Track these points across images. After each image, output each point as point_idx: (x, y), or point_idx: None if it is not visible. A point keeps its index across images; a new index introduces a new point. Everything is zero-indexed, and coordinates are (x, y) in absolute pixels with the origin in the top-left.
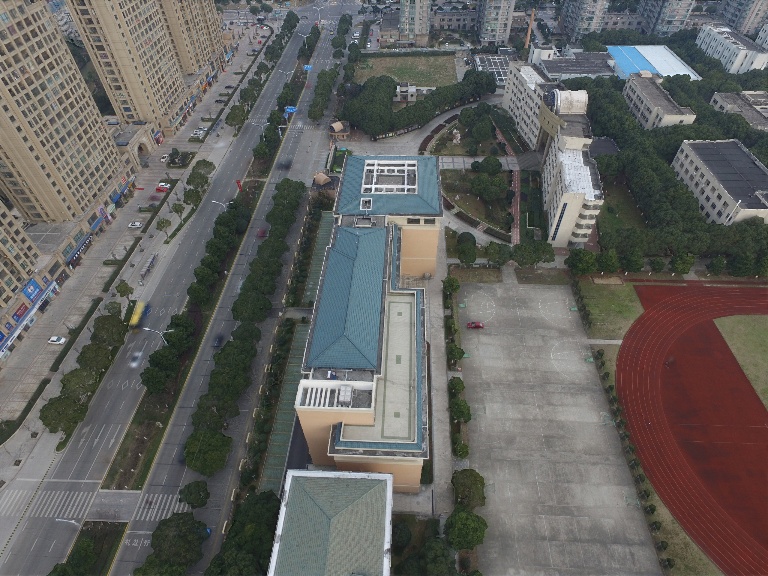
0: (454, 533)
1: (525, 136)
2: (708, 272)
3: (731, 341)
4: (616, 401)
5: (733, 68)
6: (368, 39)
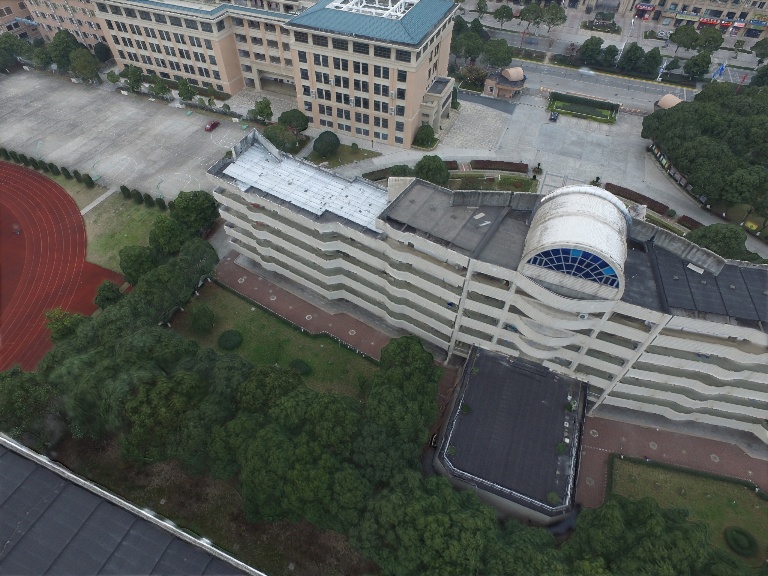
0: None
1: None
2: None
3: None
4: None
5: None
6: None
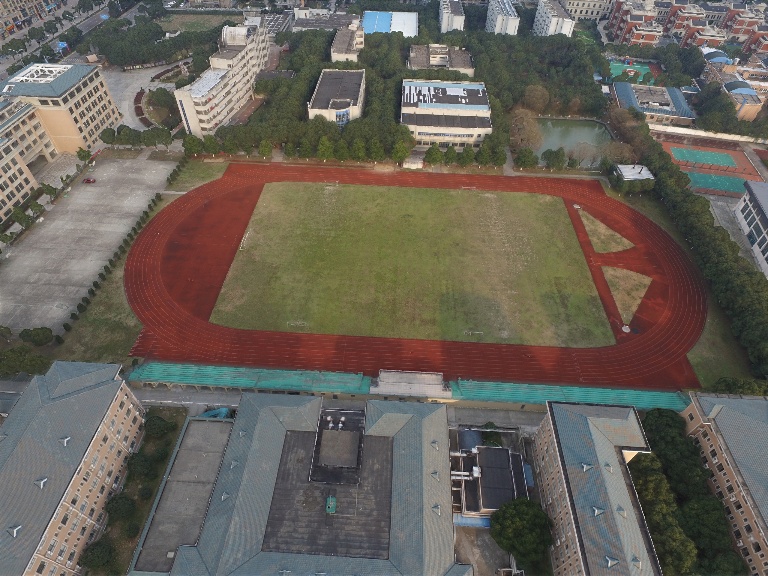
0: None
1: None
2: None
3: (264, 195)
4: (143, 220)
5: (443, 29)
6: (186, 0)
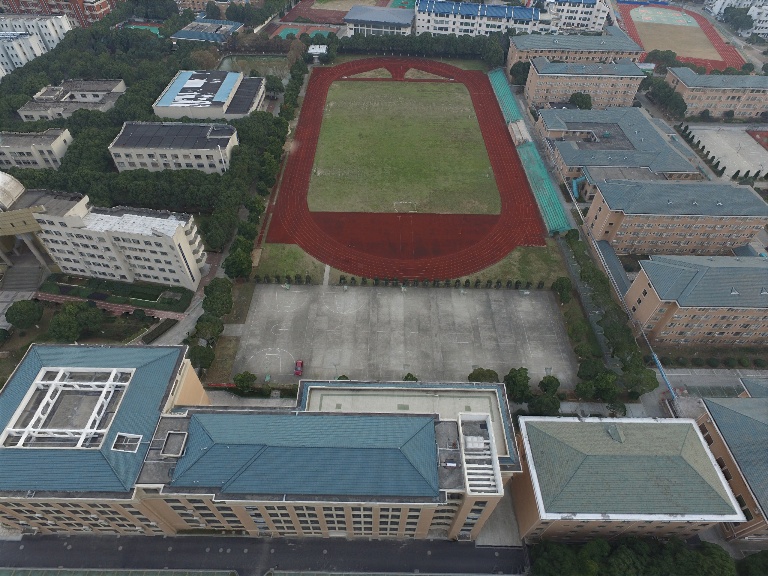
0: (527, 390)
1: None
2: (263, 197)
3: (331, 209)
4: None
5: None
6: None
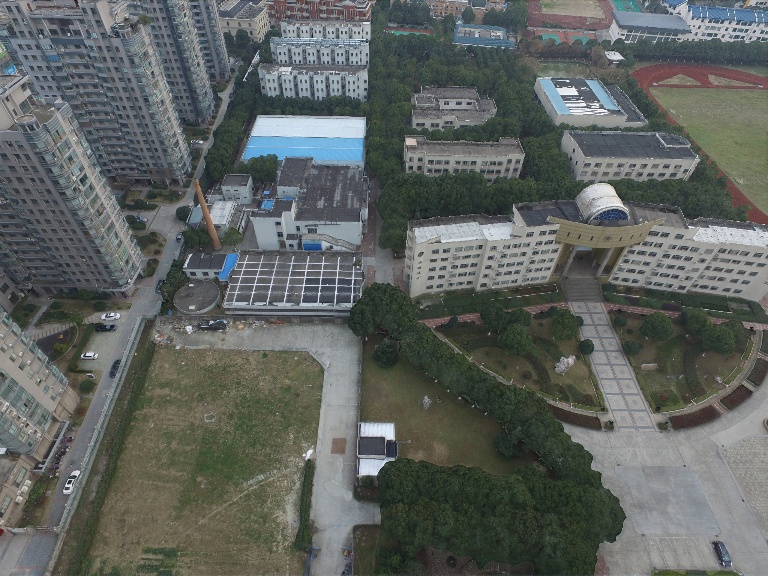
0: None
1: (515, 283)
2: None
3: None
4: None
5: None
6: None
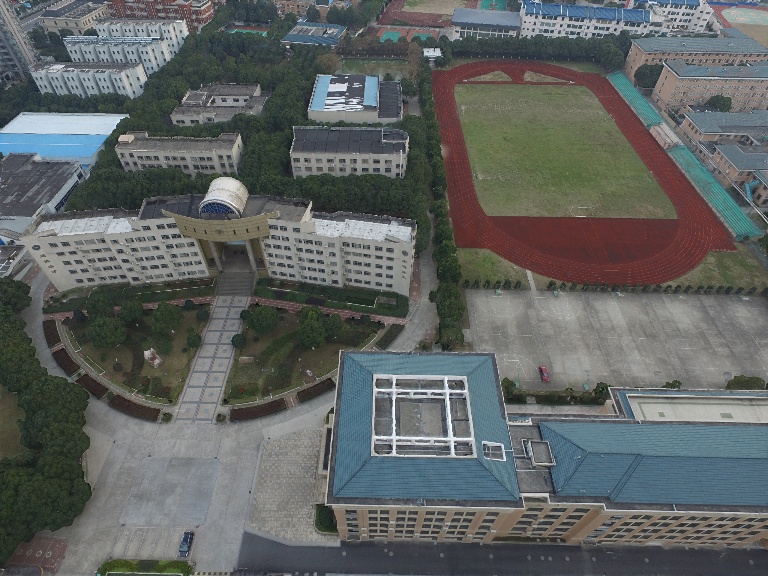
0: None
1: (171, 277)
2: None
3: (508, 214)
4: None
5: (129, 92)
6: None
